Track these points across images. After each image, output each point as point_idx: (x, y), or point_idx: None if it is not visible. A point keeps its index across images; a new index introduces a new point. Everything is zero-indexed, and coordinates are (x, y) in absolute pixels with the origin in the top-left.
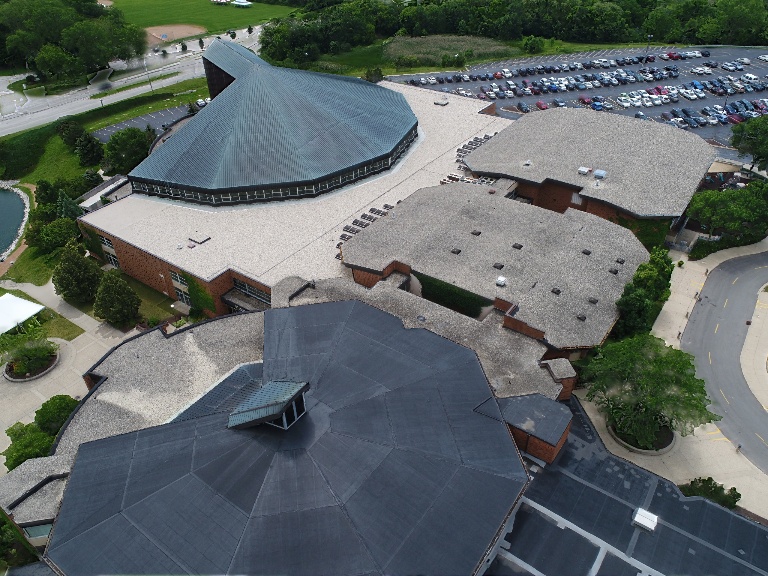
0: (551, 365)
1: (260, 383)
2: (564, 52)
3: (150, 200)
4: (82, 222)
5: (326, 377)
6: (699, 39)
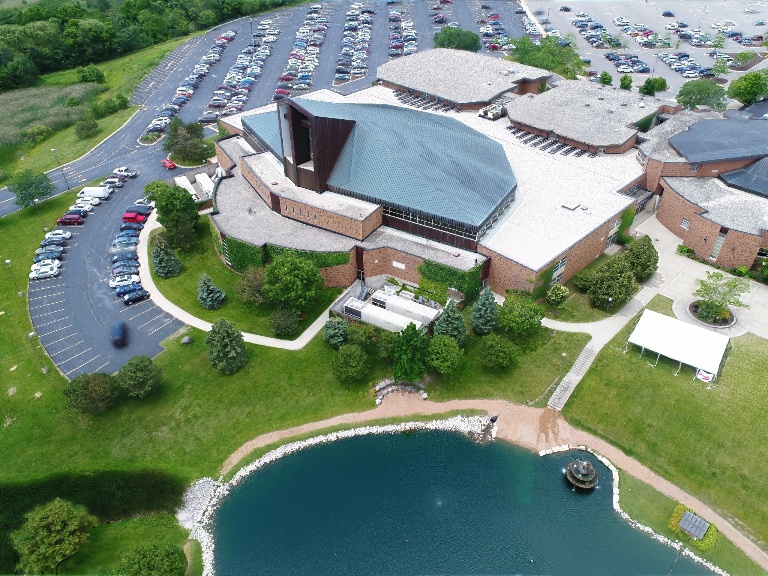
0: (702, 108)
1: (767, 158)
2: (154, 65)
3: (496, 233)
4: None
5: (756, 140)
6: (203, 25)
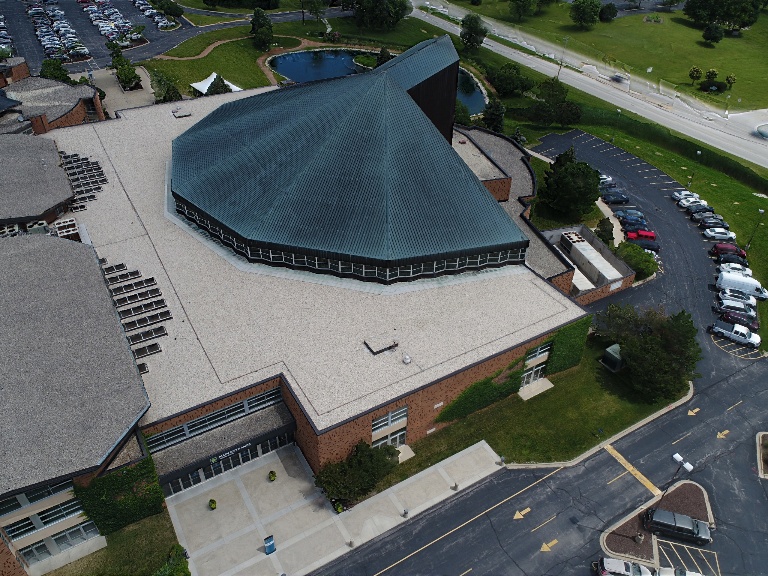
0: None
1: None
2: None
3: None
4: None
5: None
6: None
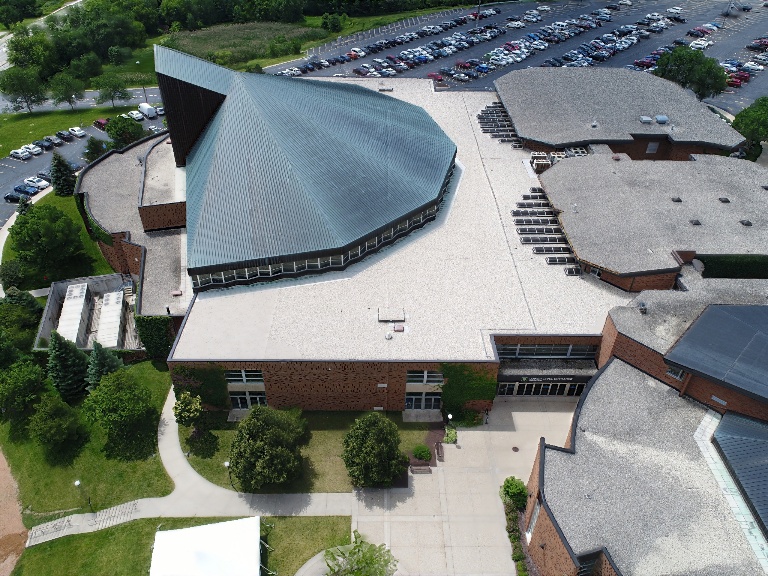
0: None
1: None
2: (379, 25)
3: (239, 293)
4: (185, 363)
5: None
6: None
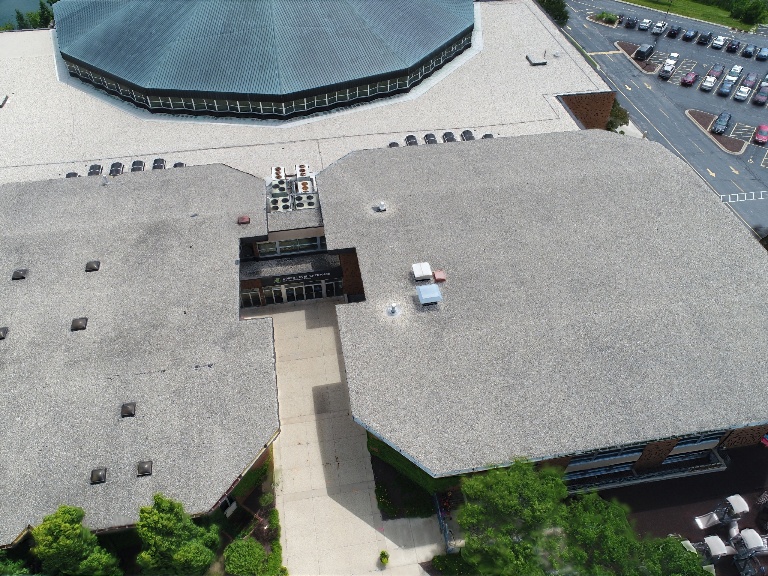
0: None
1: None
2: None
3: (53, 41)
4: None
5: None
6: None
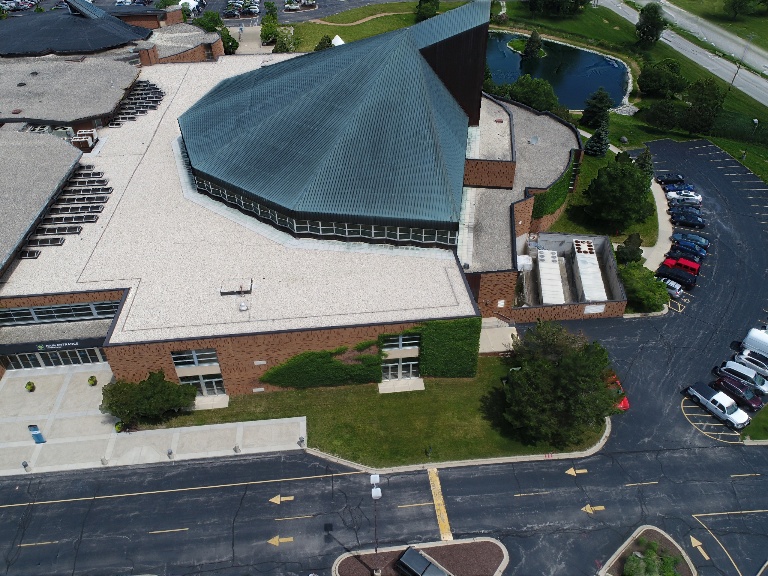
0: None
1: None
2: None
3: None
4: None
5: None
6: None
